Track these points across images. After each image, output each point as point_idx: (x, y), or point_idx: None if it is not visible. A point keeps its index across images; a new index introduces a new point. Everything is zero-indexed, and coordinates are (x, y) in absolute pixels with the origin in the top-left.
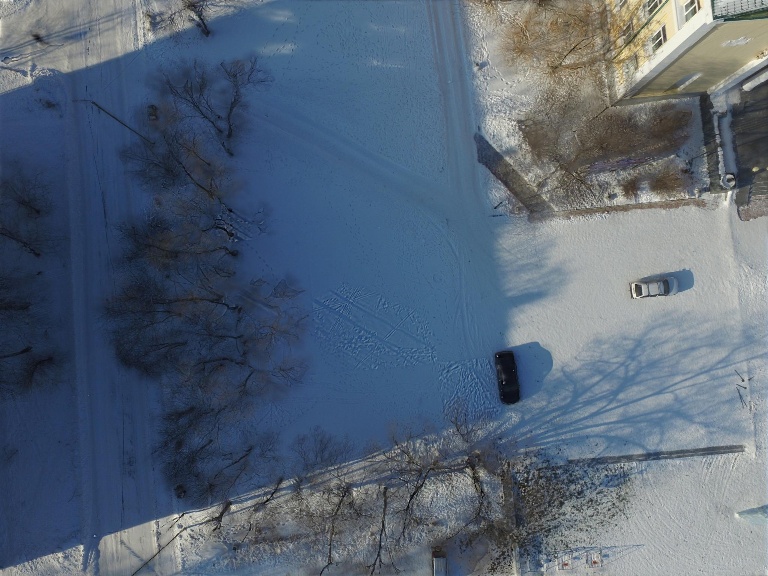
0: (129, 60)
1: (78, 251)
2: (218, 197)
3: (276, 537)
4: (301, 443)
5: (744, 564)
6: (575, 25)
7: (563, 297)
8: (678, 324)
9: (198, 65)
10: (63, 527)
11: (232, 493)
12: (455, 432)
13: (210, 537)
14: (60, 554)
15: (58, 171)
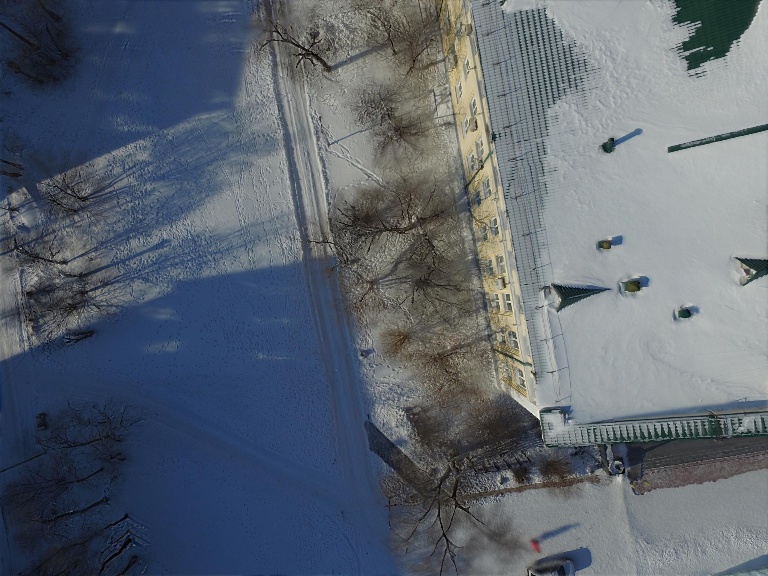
0: (16, 362)
1: None
2: None
3: None
4: None
5: None
6: None
7: None
8: None
9: (85, 366)
10: None
11: None
12: None
13: None
14: None
15: None
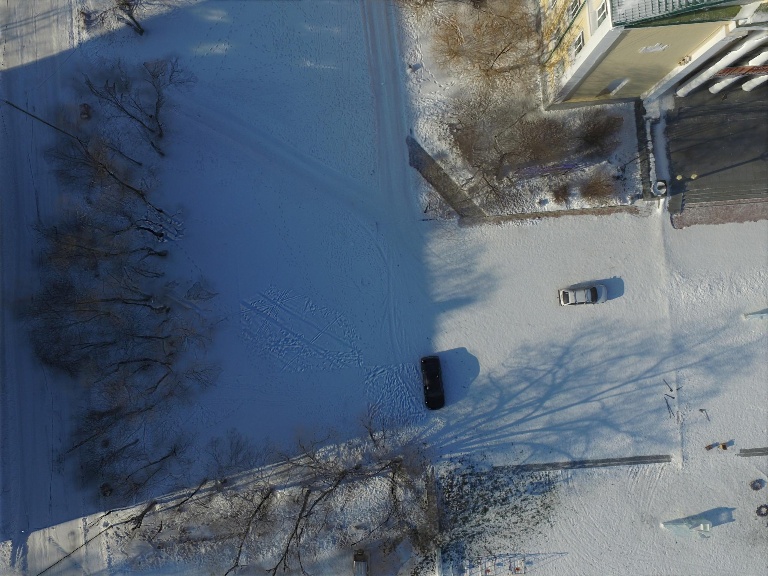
0: (64, 58)
1: (10, 249)
2: None
3: (200, 537)
4: (215, 445)
5: (668, 574)
6: (510, 27)
7: (492, 303)
8: (607, 332)
9: (132, 64)
10: None
11: (157, 492)
12: (380, 436)
13: (135, 535)
14: None
15: None
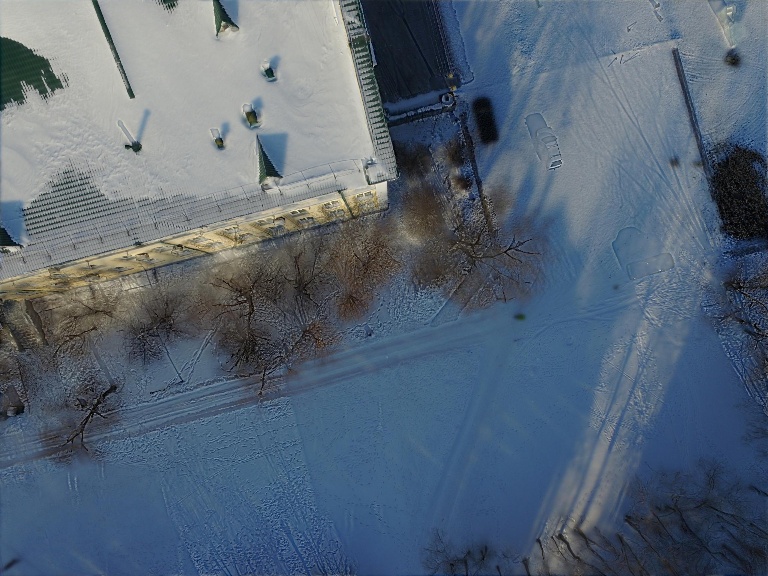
0: None
1: None
2: (544, 560)
3: None
4: (766, 453)
5: None
6: None
7: (568, 227)
8: (575, 122)
9: None
10: None
11: None
12: (706, 305)
13: None
14: None
15: None
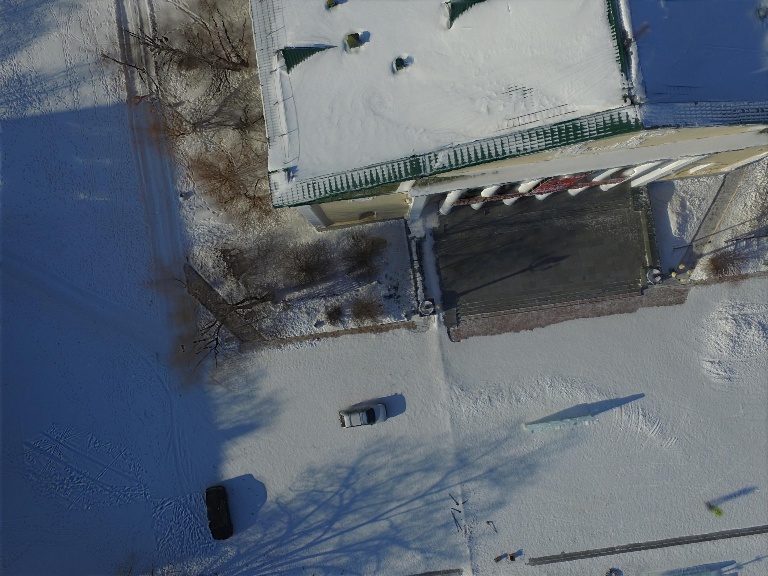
0: None
1: None
2: None
3: None
4: None
5: None
6: None
7: (276, 427)
8: (391, 450)
9: None
10: None
11: None
12: (169, 570)
13: None
14: None
15: None
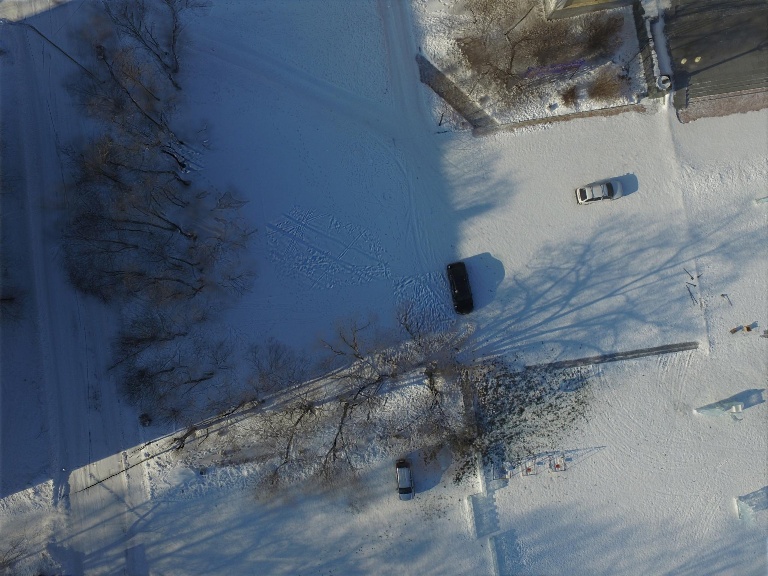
0: (77, 6)
1: (35, 192)
2: None
3: (242, 459)
4: (255, 352)
5: (705, 460)
6: None
7: (511, 207)
8: (625, 227)
9: (144, 6)
10: (32, 464)
11: (196, 418)
12: (412, 345)
13: (177, 463)
14: (30, 490)
15: (12, 116)
